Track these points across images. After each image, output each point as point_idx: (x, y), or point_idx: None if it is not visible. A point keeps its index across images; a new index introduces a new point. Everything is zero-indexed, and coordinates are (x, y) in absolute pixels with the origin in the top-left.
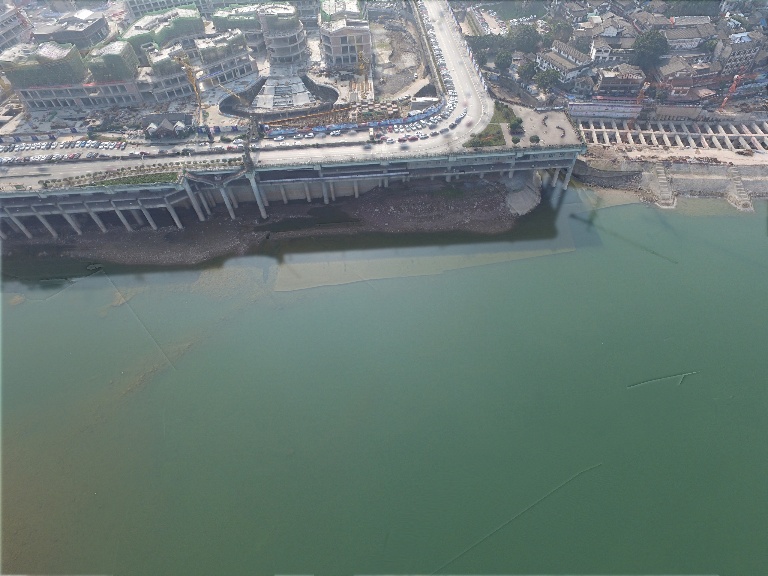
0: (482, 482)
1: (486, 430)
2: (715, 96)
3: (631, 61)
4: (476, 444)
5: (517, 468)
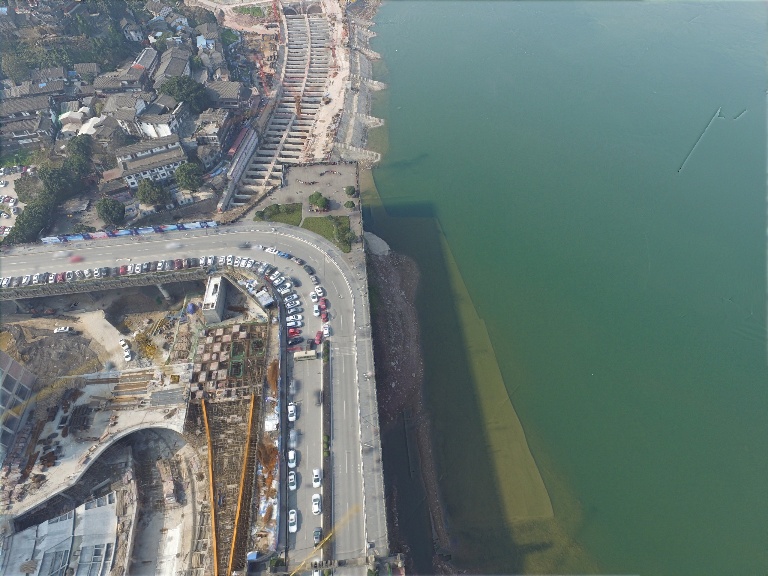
0: (752, 260)
1: (665, 282)
2: None
3: (190, 112)
4: (695, 280)
5: (755, 228)
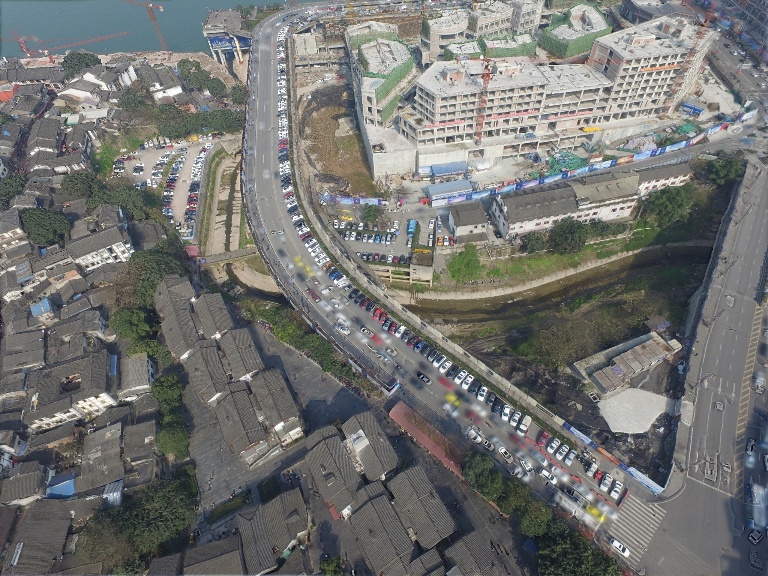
0: None
1: None
2: None
3: None
4: None
5: None
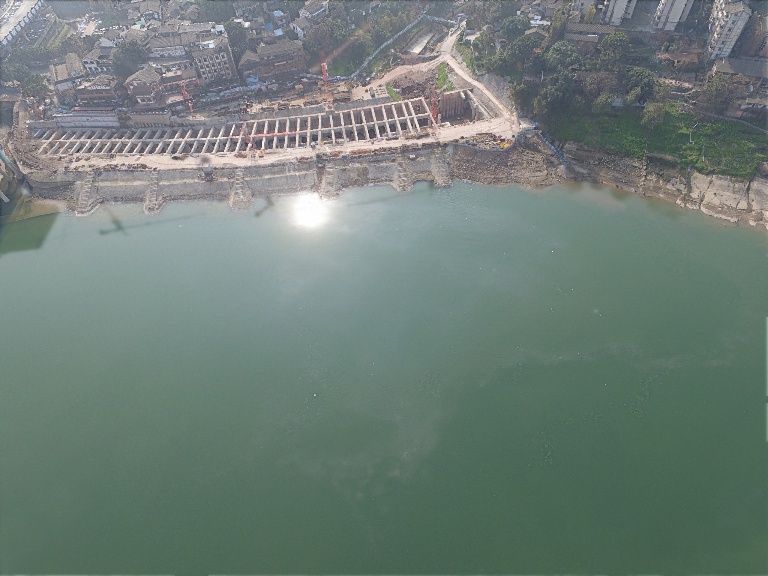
0: None
1: None
2: (190, 102)
3: None
4: None
5: None
